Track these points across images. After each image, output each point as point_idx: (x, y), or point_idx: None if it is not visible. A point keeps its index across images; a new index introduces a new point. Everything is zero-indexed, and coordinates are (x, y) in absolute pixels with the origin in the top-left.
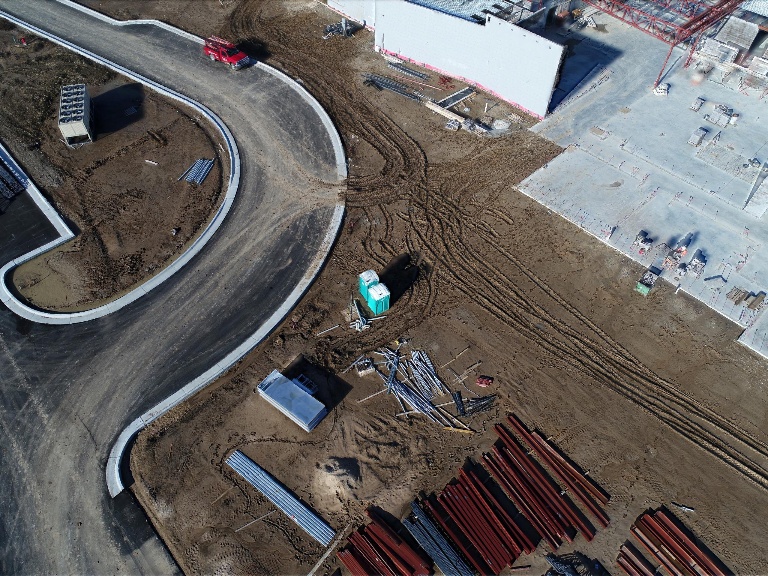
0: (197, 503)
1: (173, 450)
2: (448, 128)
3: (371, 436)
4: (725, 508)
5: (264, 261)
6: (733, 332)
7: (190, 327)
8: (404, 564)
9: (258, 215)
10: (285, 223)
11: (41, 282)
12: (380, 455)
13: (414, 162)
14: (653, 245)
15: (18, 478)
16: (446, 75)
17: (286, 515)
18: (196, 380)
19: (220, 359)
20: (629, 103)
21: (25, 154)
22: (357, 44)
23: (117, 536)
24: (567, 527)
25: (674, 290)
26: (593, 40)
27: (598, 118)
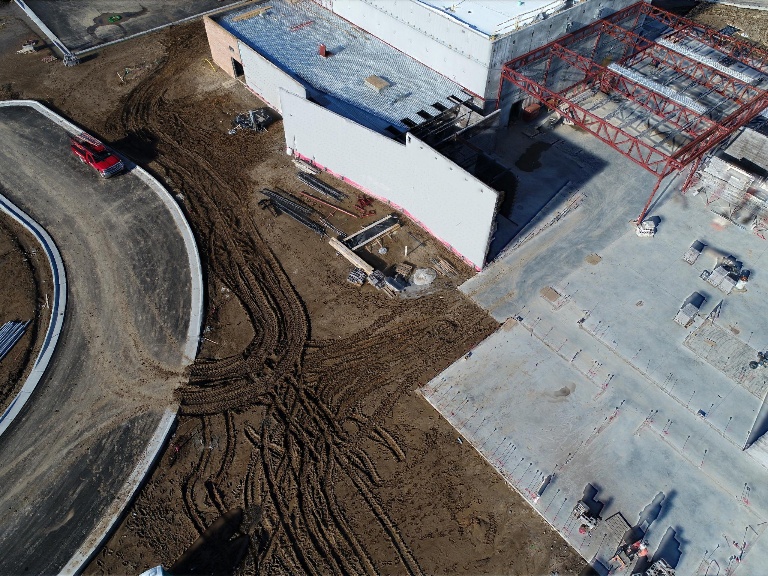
0: None
1: None
2: (350, 281)
3: None
4: None
5: (34, 513)
6: None
7: None
8: None
9: (54, 424)
10: (86, 441)
11: None
12: None
13: (292, 337)
14: (602, 515)
15: None
16: (368, 194)
17: None
18: None
19: None
20: (601, 247)
21: None
22: (267, 142)
23: None
24: None
25: None
26: (567, 144)
27: (555, 272)
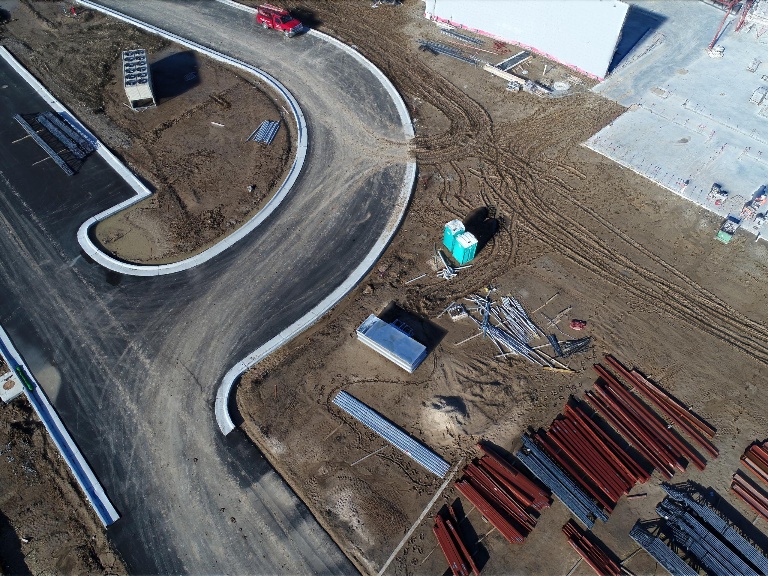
0: (309, 440)
1: (278, 391)
2: (509, 90)
3: (472, 376)
4: None
5: (343, 215)
6: None
7: (278, 277)
8: (523, 493)
9: (331, 173)
10: (359, 180)
11: (124, 237)
12: (484, 394)
13: (479, 122)
14: (728, 197)
15: (128, 418)
16: (500, 40)
17: (399, 450)
18: (292, 326)
19: (313, 306)
20: (686, 65)
21: (91, 117)
22: (407, 12)
23: (235, 471)
24: (678, 458)
25: (754, 238)
26: (642, 6)
27: (657, 79)
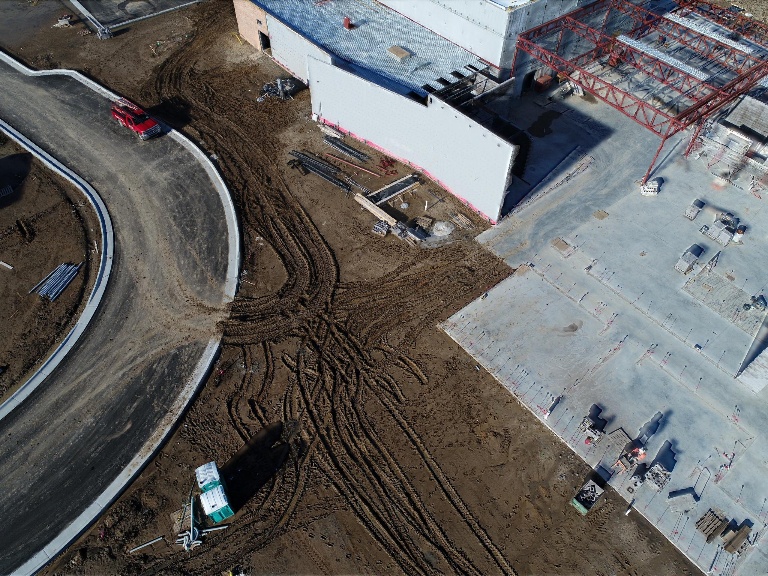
0: None
1: None
2: (375, 232)
3: None
4: None
5: (96, 424)
6: None
7: None
8: None
9: (109, 351)
10: (139, 365)
11: None
12: None
13: (323, 279)
14: (606, 430)
15: None
16: (389, 156)
17: None
18: None
19: None
20: (607, 204)
21: None
22: (294, 109)
23: None
24: None
25: (625, 508)
26: (577, 113)
27: (565, 225)
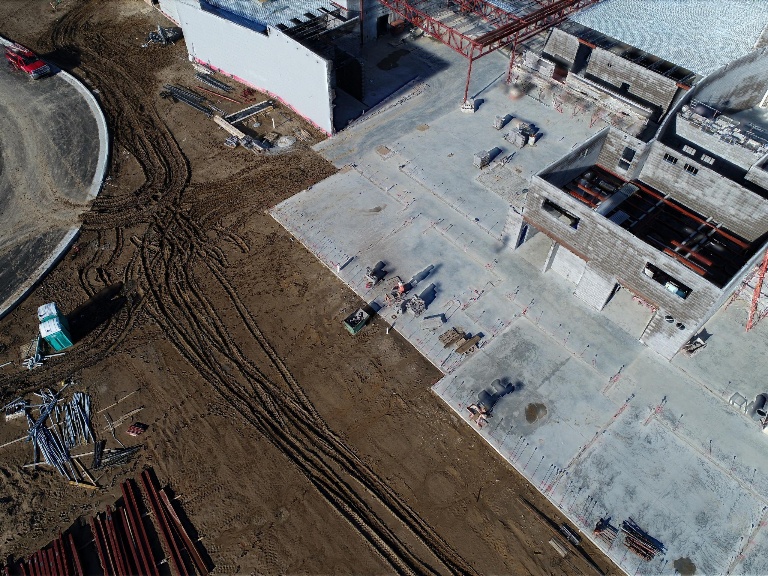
0: None
1: None
2: (226, 145)
3: None
4: None
5: None
6: (431, 379)
7: None
8: None
9: None
10: (8, 247)
11: None
12: None
13: (176, 181)
14: (385, 278)
15: None
16: (251, 87)
17: None
18: None
19: None
20: (431, 120)
21: None
22: (174, 53)
23: None
24: None
25: None
26: (423, 51)
27: (390, 136)
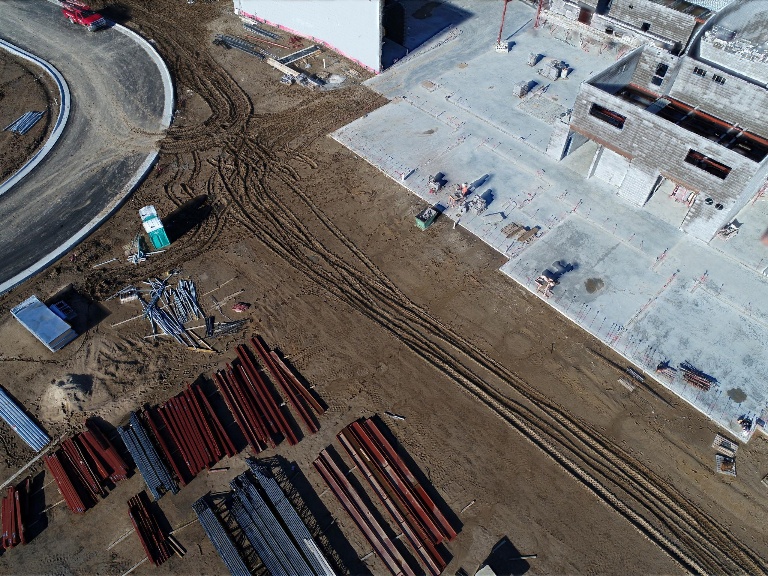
0: None
1: None
2: (282, 82)
3: (114, 356)
4: (435, 417)
5: (63, 202)
6: (498, 262)
7: None
8: (106, 466)
9: (71, 161)
10: (95, 168)
11: None
12: (117, 372)
13: (240, 113)
14: (446, 185)
15: None
16: (297, 35)
17: (8, 425)
18: None
19: None
20: (469, 59)
21: None
22: (219, 8)
23: None
24: (275, 433)
25: (453, 226)
26: (454, 3)
27: (433, 73)
